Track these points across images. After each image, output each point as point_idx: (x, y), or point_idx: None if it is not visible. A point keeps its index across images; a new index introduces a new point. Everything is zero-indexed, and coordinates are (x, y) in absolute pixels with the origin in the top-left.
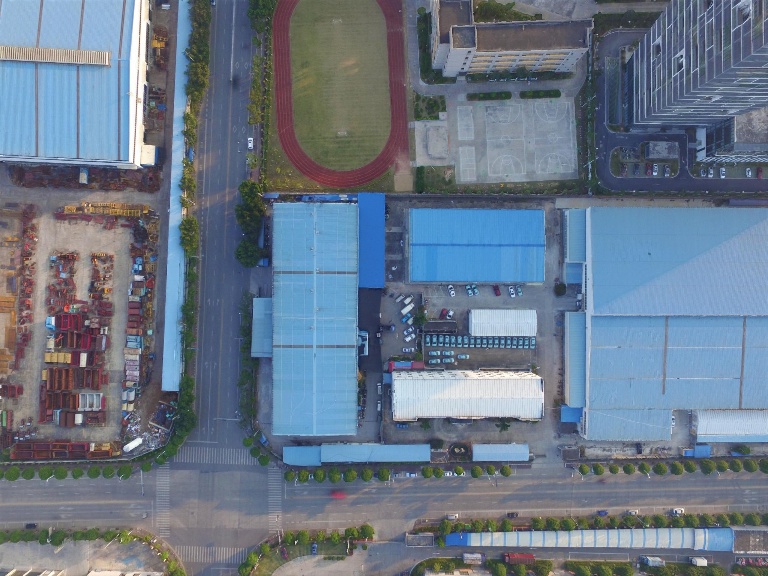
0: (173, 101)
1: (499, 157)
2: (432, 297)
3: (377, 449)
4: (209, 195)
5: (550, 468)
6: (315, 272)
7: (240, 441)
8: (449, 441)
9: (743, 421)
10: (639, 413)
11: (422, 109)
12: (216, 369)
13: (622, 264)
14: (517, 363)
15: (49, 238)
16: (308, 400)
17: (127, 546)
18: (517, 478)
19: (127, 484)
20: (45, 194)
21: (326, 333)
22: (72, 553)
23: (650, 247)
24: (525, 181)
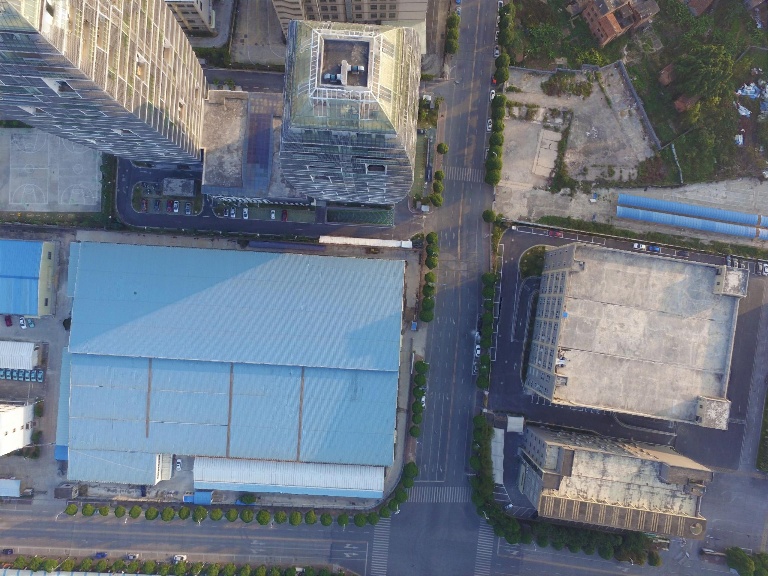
0: None
1: (21, 186)
2: None
3: None
4: None
5: (52, 505)
6: None
7: None
8: None
9: (240, 469)
10: (122, 455)
11: None
12: None
13: (106, 302)
14: (25, 396)
15: None
16: None
17: None
18: (17, 514)
19: None
20: None
21: None
22: None
23: (137, 286)
24: (46, 211)
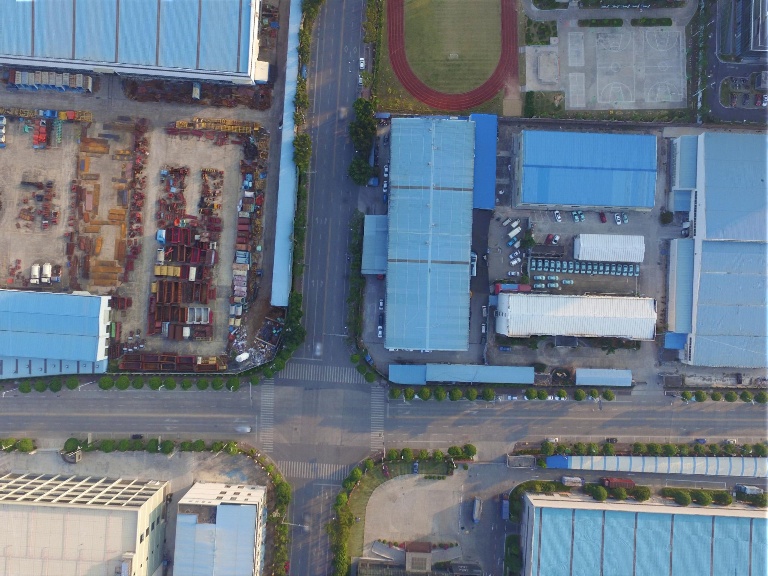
0: (286, 19)
1: (609, 84)
2: (538, 222)
3: (482, 370)
4: (319, 114)
5: (650, 395)
6: (432, 188)
7: (344, 359)
8: (551, 366)
9: None
10: (745, 340)
11: (533, 34)
12: (322, 287)
13: (735, 190)
14: (620, 290)
15: (160, 152)
16: (422, 315)
17: (231, 459)
18: (617, 404)
19: (232, 398)
20: (157, 108)
21: (441, 249)
22: (177, 464)
23: (763, 174)
24: (634, 109)
